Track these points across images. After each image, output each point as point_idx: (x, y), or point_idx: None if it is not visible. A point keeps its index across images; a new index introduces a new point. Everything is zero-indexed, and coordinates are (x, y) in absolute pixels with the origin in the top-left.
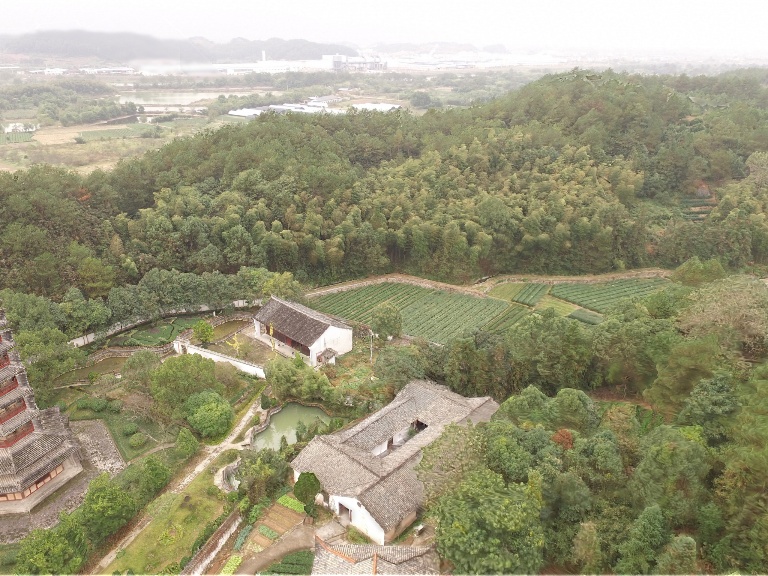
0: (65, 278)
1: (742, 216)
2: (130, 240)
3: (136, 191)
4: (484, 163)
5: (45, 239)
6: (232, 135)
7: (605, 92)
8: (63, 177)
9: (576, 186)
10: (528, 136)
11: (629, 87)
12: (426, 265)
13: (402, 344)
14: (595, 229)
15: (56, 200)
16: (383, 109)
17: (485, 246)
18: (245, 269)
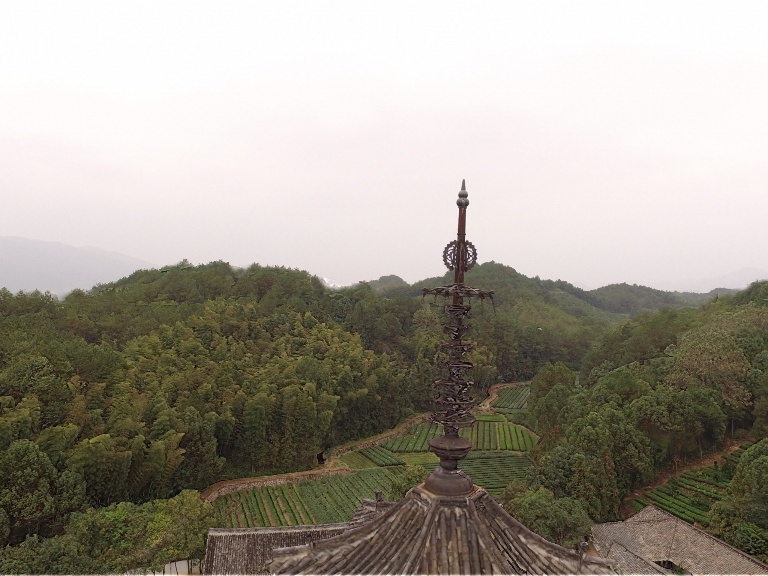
0: None
1: None
2: None
3: None
4: (243, 330)
5: None
6: None
7: (268, 271)
8: None
9: (344, 343)
10: None
11: (279, 269)
12: (268, 454)
13: None
14: (390, 378)
15: None
16: (13, 290)
17: (331, 410)
18: (95, 512)
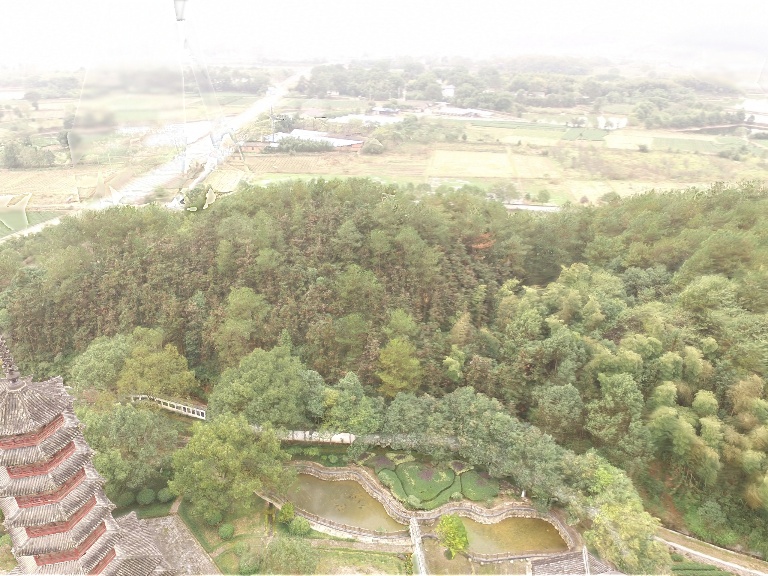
0: (368, 352)
1: None
2: (492, 323)
3: (559, 251)
4: None
5: (382, 292)
6: (740, 204)
7: None
8: (472, 213)
9: None
10: None
11: None
12: None
13: None
14: None
15: (423, 246)
16: None
17: None
18: (589, 459)
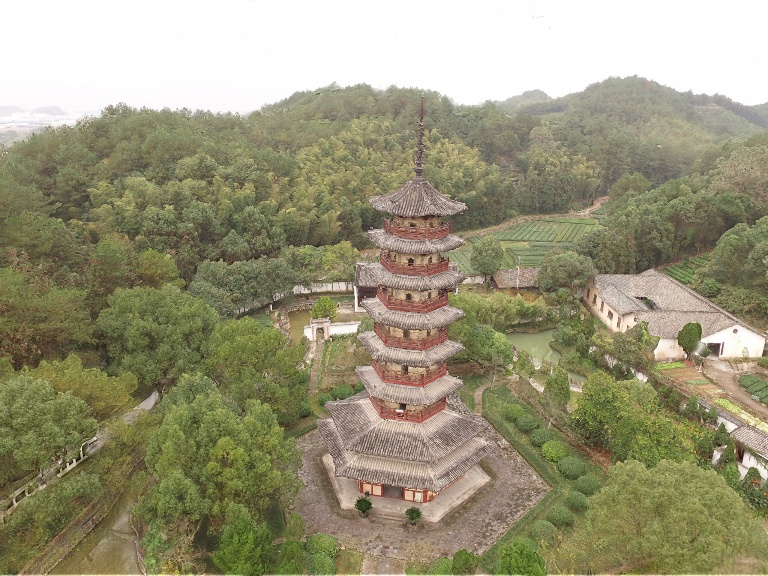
0: None
1: (567, 165)
2: None
3: None
4: (381, 144)
5: None
6: (118, 126)
7: (403, 92)
8: None
9: (461, 155)
10: (387, 123)
11: (413, 90)
12: None
13: (504, 274)
14: (497, 185)
15: None
16: (213, 111)
17: None
18: (294, 248)
